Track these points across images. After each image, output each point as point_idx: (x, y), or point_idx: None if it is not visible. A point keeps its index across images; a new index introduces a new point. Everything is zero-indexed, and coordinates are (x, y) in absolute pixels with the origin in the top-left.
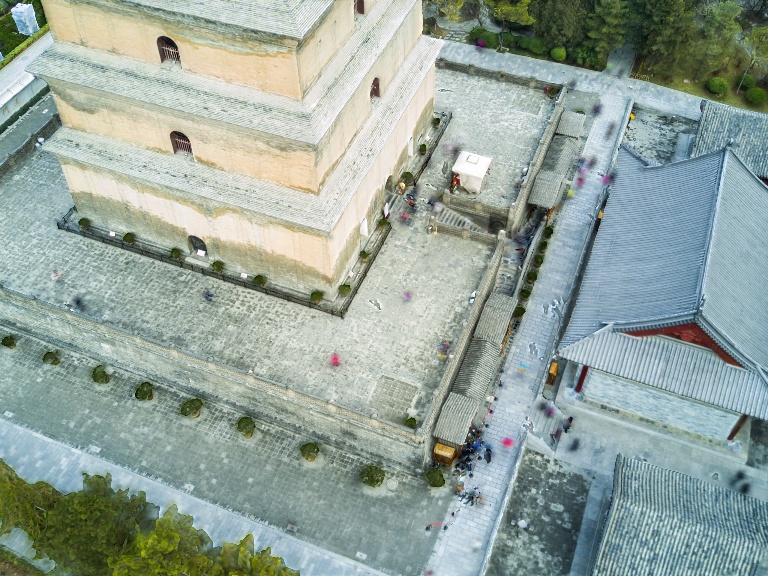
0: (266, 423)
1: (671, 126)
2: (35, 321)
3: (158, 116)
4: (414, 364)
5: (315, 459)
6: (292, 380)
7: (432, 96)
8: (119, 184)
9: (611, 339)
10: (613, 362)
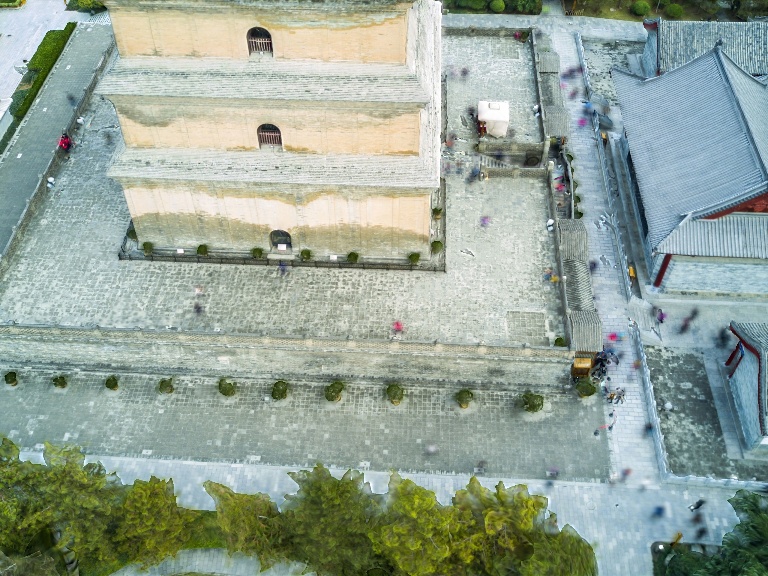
0: (407, 387)
1: (617, 50)
2: (136, 355)
3: (246, 112)
4: (530, 294)
5: (468, 405)
6: (429, 337)
7: None
8: (194, 195)
9: (693, 227)
10: (701, 246)
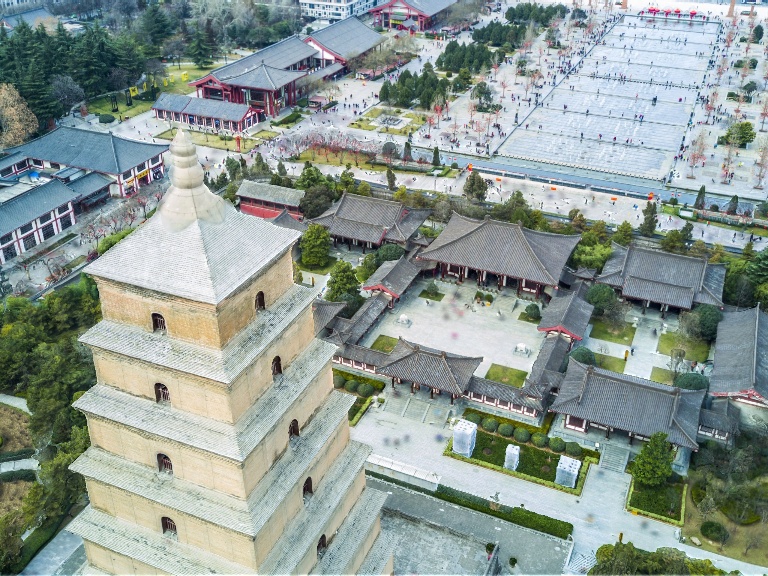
0: None
1: None
2: None
3: None
4: None
5: None
6: None
7: None
8: None
9: None
10: None
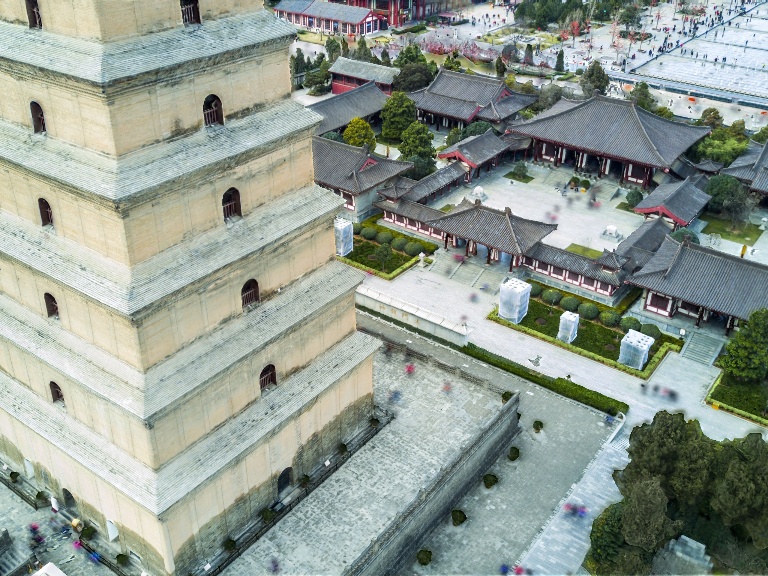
0: None
1: None
2: None
3: None
4: None
5: None
6: None
7: None
8: None
9: None
10: None
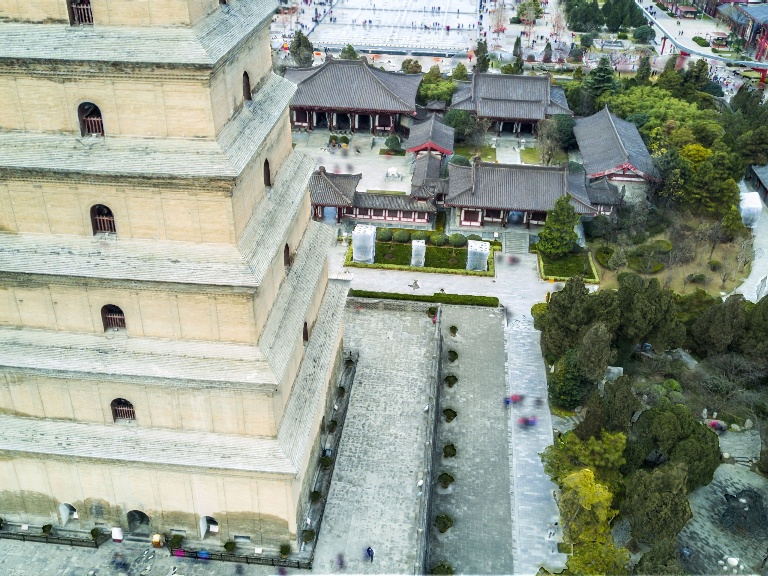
0: None
1: None
2: None
3: None
4: None
5: None
6: None
7: (286, 517)
8: None
9: None
10: None
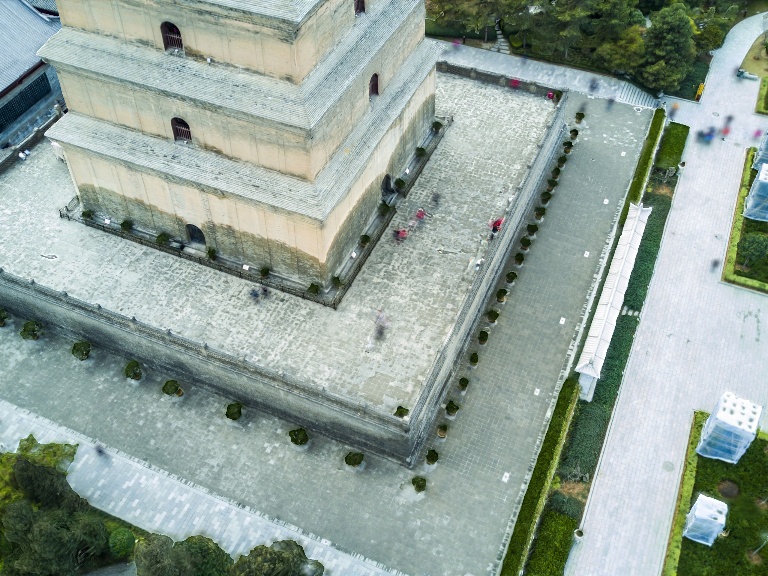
0: None
1: None
2: None
3: None
4: None
5: None
6: None
7: None
8: None
9: None
10: None
